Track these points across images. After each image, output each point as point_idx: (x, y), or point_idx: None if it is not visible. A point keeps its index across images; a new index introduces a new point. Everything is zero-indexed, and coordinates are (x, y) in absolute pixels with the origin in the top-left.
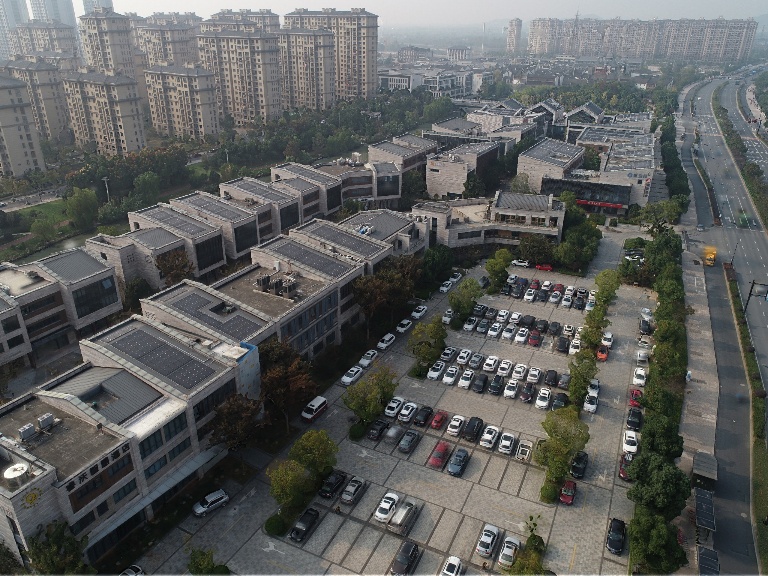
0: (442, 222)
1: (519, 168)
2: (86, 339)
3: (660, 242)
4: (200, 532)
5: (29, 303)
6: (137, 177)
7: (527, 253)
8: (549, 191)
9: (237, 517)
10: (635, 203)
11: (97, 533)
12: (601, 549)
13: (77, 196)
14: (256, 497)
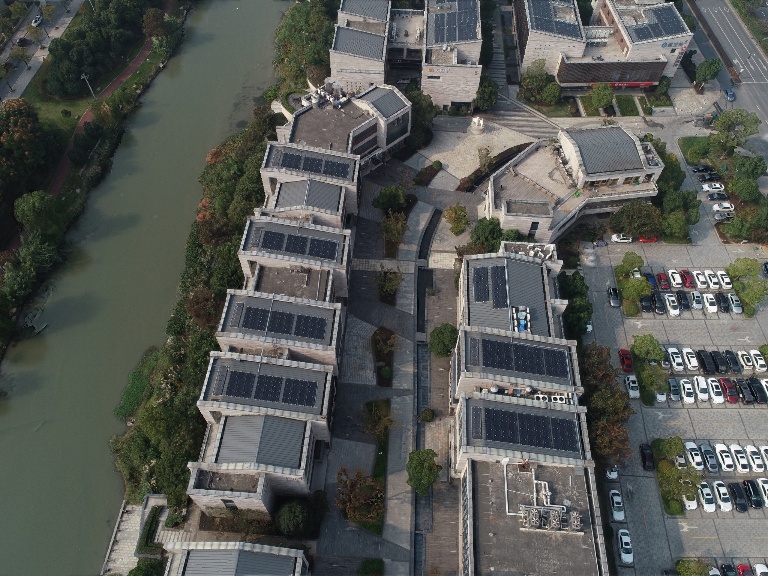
0: (545, 225)
1: (529, 47)
2: None
3: (747, 171)
4: None
5: None
6: (15, 206)
7: (636, 233)
8: (572, 77)
9: None
10: (663, 75)
11: None
12: None
13: None
14: None
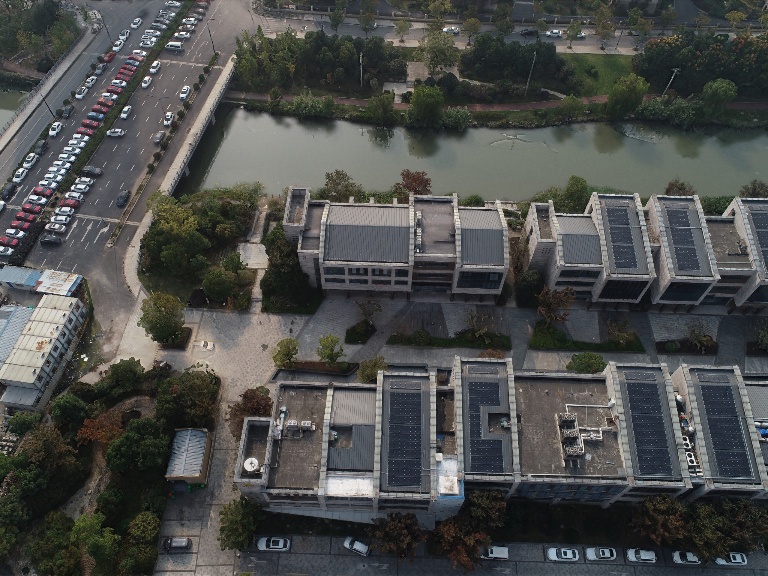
0: None
1: None
2: (384, 372)
3: None
4: (334, 557)
5: (426, 261)
6: (715, 80)
7: None
8: None
9: (358, 573)
10: None
11: (285, 507)
12: None
13: (626, 85)
14: (381, 573)
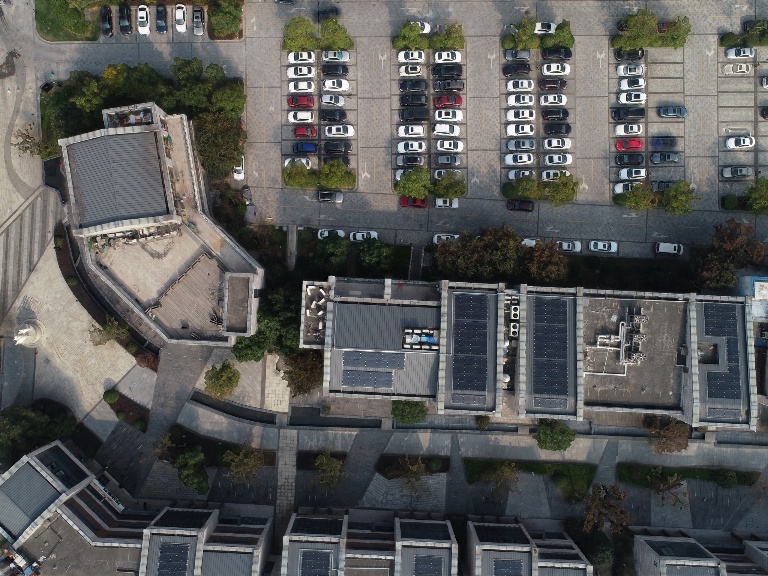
0: (256, 281)
1: None
2: None
3: None
4: None
5: None
6: None
7: None
8: None
9: None
10: None
11: None
12: (706, 1)
13: None
14: None
